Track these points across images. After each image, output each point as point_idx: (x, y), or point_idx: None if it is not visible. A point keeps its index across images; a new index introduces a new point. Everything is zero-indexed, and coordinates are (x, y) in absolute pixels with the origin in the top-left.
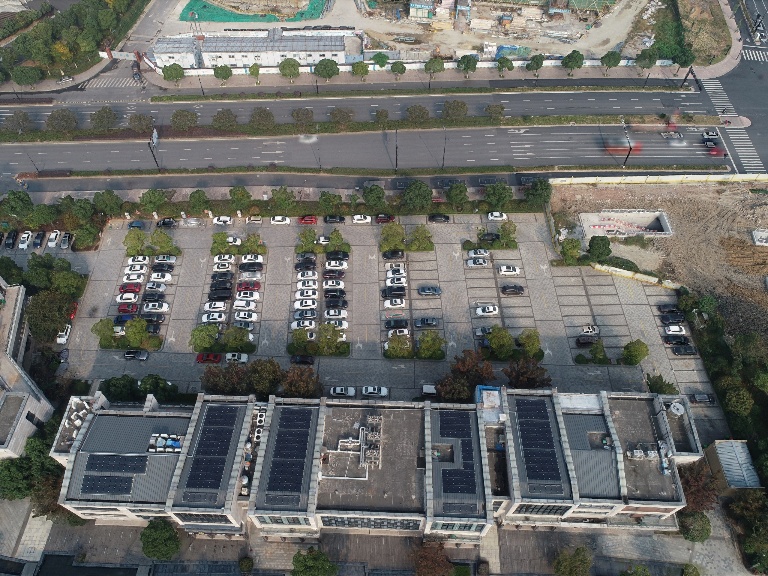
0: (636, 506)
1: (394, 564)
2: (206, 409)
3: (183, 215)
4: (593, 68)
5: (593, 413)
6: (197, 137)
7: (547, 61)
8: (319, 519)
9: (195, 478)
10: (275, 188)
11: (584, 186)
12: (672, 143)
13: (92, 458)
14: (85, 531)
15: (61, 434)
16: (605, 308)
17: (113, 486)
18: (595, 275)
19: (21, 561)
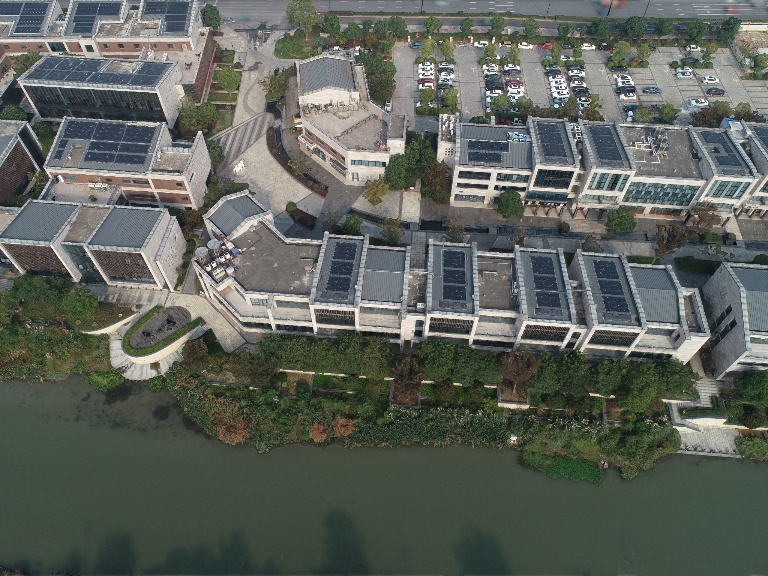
0: None
1: None
2: (536, 124)
3: (451, 40)
4: None
5: None
6: None
7: None
8: None
9: (548, 152)
10: (513, 27)
11: (757, 33)
12: None
13: (471, 142)
14: (444, 209)
15: (441, 133)
16: None
17: (489, 158)
18: None
19: (406, 222)
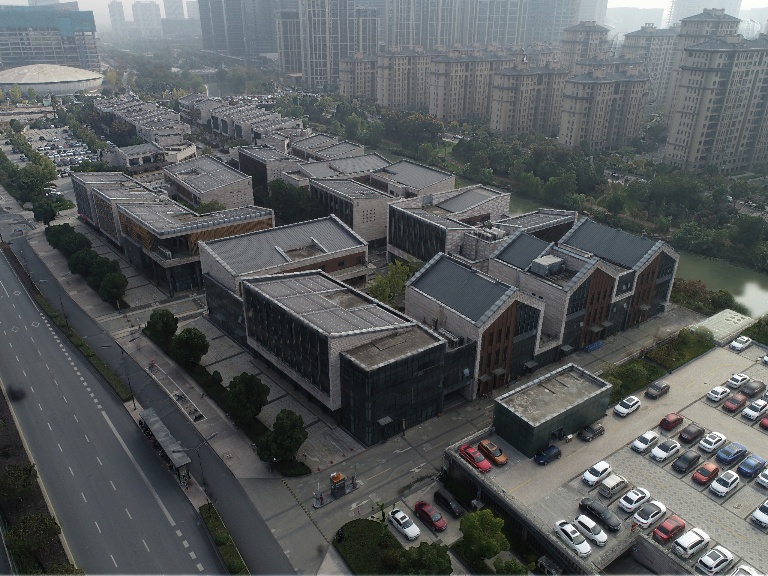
0: None
1: None
2: None
3: None
4: None
5: None
6: None
7: None
8: None
9: None
10: None
11: None
12: None
13: None
14: None
15: None
16: None
17: None
18: None
19: None
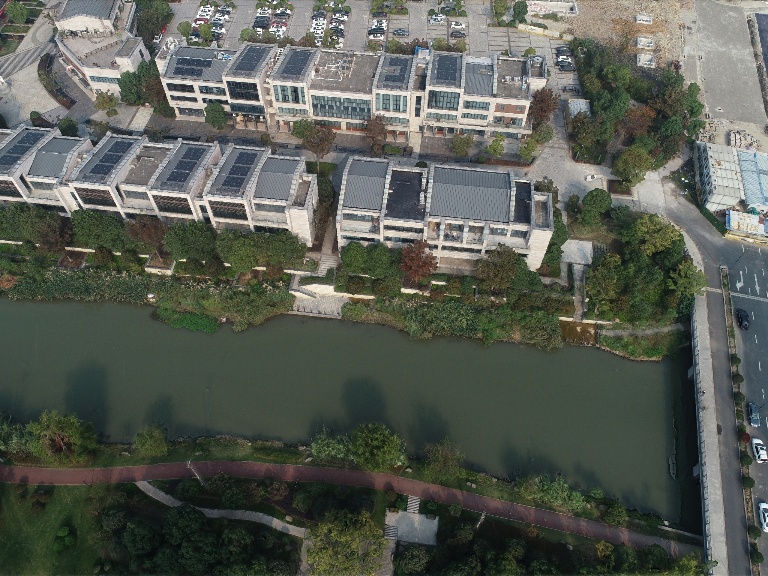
0: (502, 104)
1: (355, 145)
2: (248, 48)
3: None
4: None
5: (486, 64)
6: None
7: None
8: (311, 102)
9: (240, 67)
10: None
11: None
12: None
13: (180, 59)
14: (169, 122)
15: (161, 53)
16: (520, 48)
17: (192, 72)
18: (517, 32)
19: (132, 131)
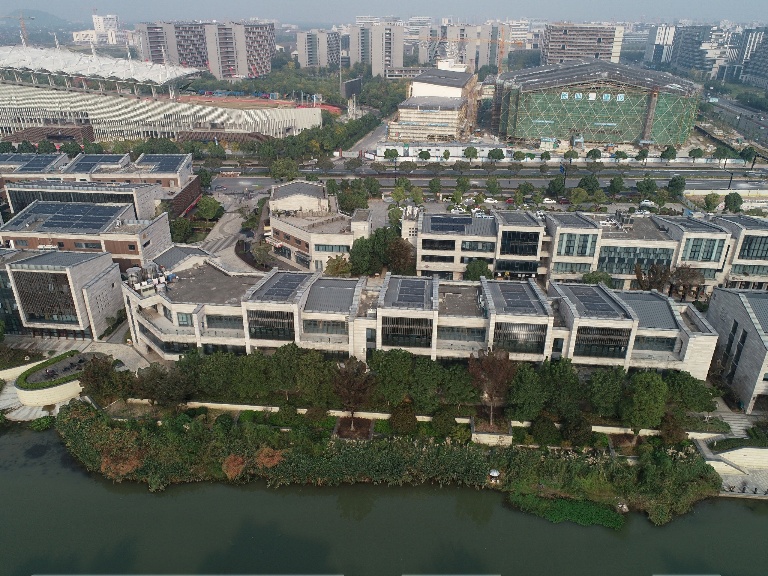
0: None
1: None
2: None
3: None
4: (682, 164)
5: None
6: (415, 178)
7: (649, 158)
8: (598, 254)
9: None
10: None
11: (704, 196)
12: (759, 185)
13: (434, 218)
14: None
15: None
16: None
17: (452, 228)
18: None
19: None
